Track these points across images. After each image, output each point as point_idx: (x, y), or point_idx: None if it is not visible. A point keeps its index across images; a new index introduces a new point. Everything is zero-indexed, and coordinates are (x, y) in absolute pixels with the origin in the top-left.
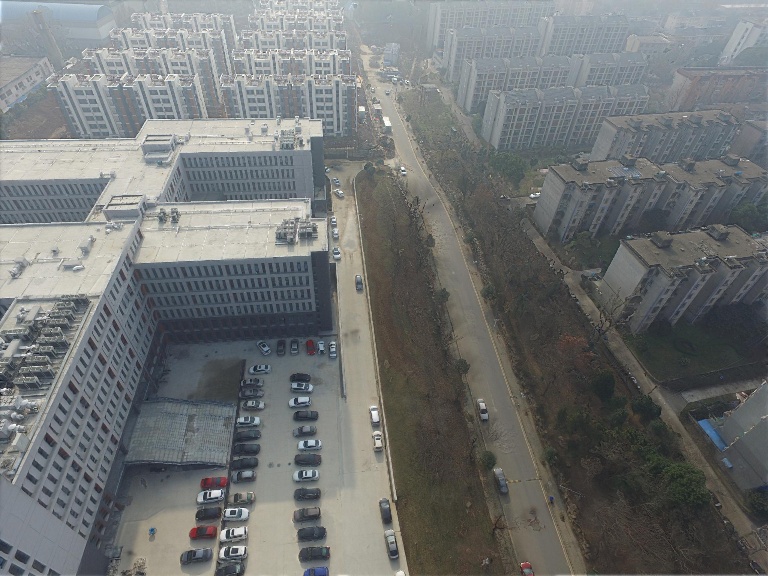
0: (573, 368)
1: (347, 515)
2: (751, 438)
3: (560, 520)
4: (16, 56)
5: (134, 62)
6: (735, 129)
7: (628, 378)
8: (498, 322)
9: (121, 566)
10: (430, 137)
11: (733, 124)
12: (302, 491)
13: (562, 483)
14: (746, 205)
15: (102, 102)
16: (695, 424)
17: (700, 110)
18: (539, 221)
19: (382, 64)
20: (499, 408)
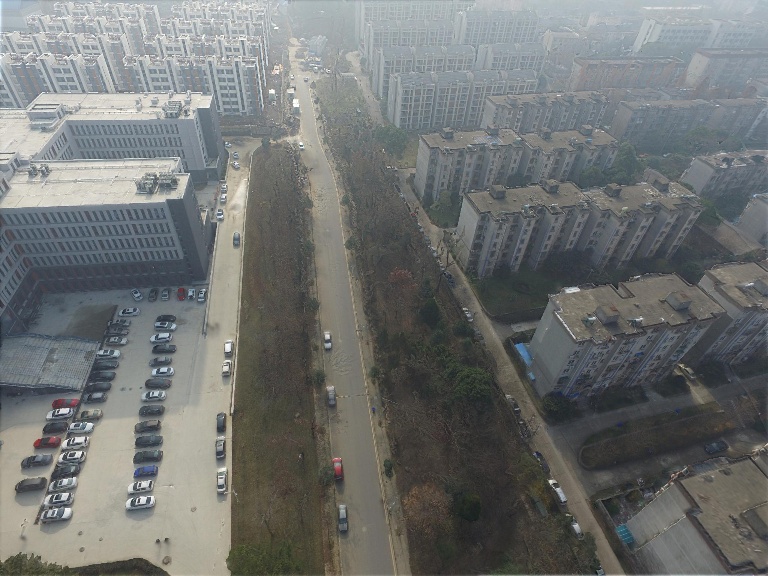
0: (417, 306)
1: (186, 427)
2: (542, 349)
3: (378, 426)
4: None
5: (45, 45)
6: (605, 107)
7: (461, 311)
8: (358, 270)
9: None
10: (332, 116)
11: (602, 102)
12: (146, 408)
13: (385, 396)
14: (591, 168)
15: (6, 80)
16: (514, 348)
17: (577, 91)
18: (418, 187)
19: (307, 55)
20: (344, 339)
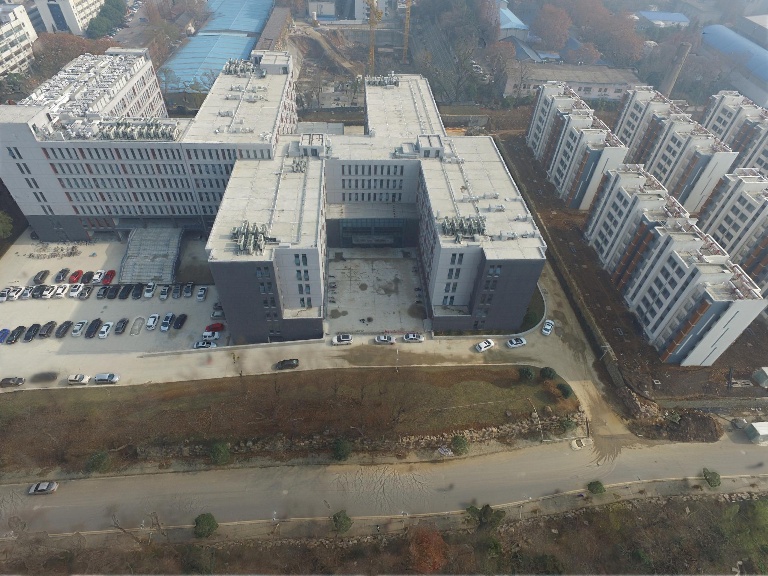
0: None
1: (31, 356)
2: None
3: None
4: (635, 73)
5: None
6: None
7: None
8: None
9: (82, 247)
10: (736, 507)
11: None
12: (66, 324)
13: None
14: None
15: (547, 119)
16: None
17: None
18: None
19: None
20: (35, 513)
